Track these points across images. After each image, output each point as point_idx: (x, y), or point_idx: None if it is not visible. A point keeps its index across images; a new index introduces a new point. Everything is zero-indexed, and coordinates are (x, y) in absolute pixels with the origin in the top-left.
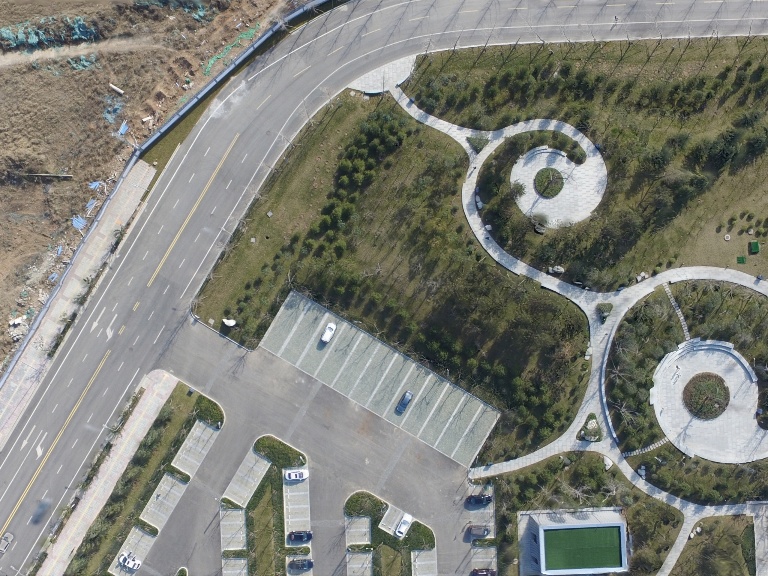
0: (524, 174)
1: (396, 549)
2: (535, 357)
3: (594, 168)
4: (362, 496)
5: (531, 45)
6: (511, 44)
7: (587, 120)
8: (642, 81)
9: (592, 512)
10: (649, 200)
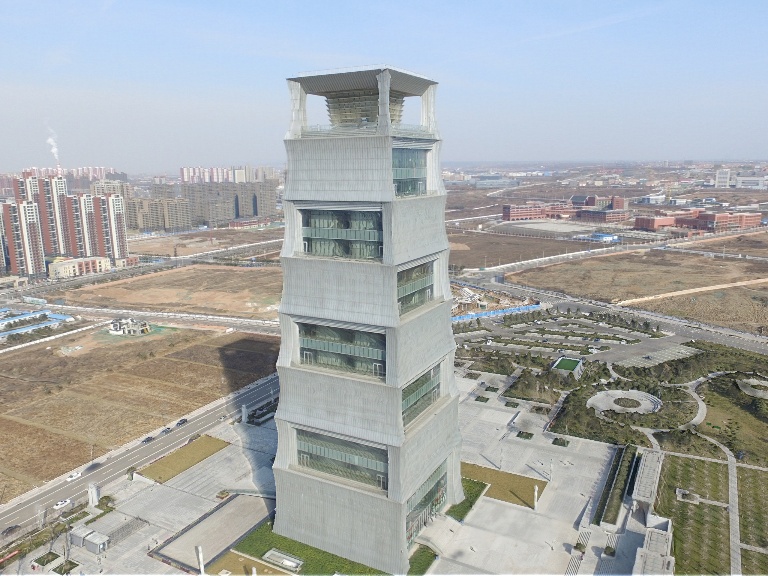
0: None
1: None
2: None
3: None
4: (610, 348)
5: None
6: None
7: None
8: None
9: None
10: None
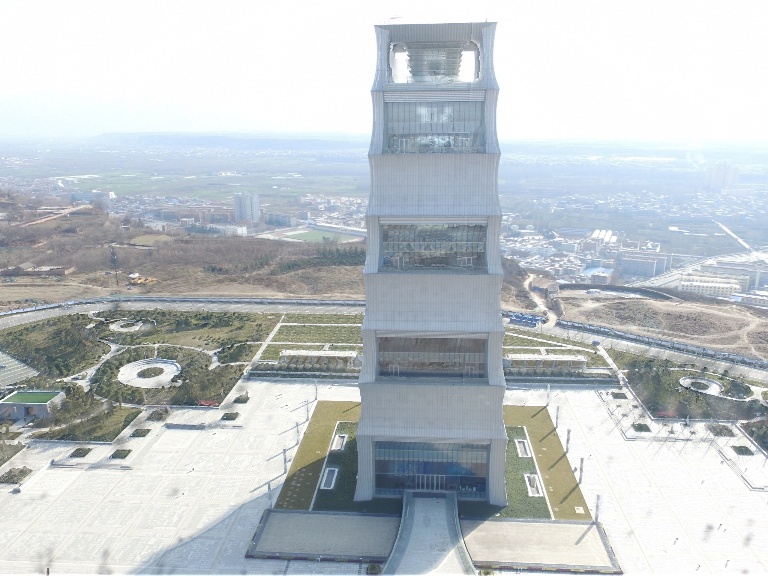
0: None
1: None
2: None
3: None
4: None
5: None
6: None
7: None
8: (190, 315)
9: None
10: None
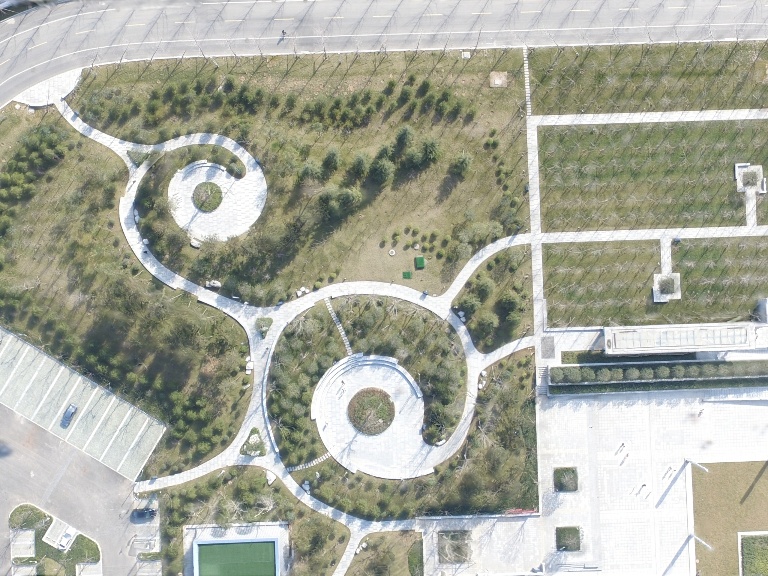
0: (183, 188)
1: (59, 562)
2: (196, 371)
3: (254, 182)
4: (25, 509)
5: (197, 59)
6: (177, 58)
7: (247, 134)
8: (307, 95)
9: (258, 527)
10: (307, 215)
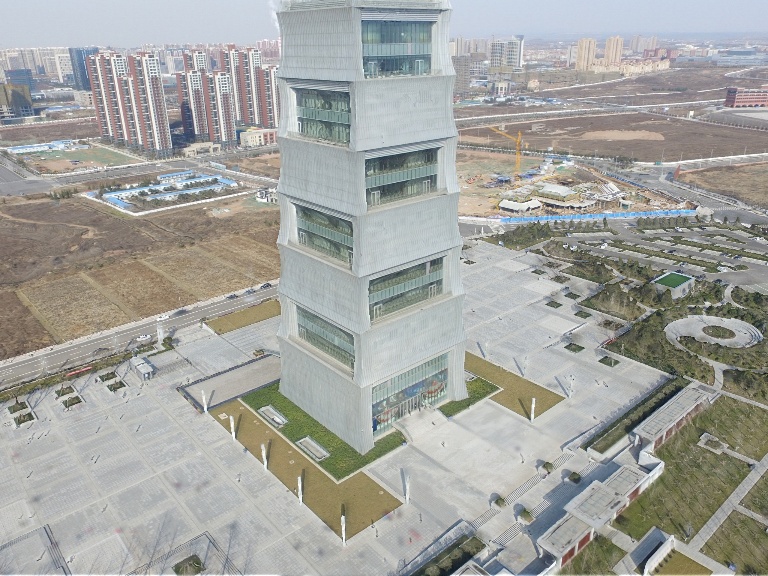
0: None
1: None
2: None
3: None
4: (747, 268)
5: None
6: None
7: None
8: None
9: None
10: None
